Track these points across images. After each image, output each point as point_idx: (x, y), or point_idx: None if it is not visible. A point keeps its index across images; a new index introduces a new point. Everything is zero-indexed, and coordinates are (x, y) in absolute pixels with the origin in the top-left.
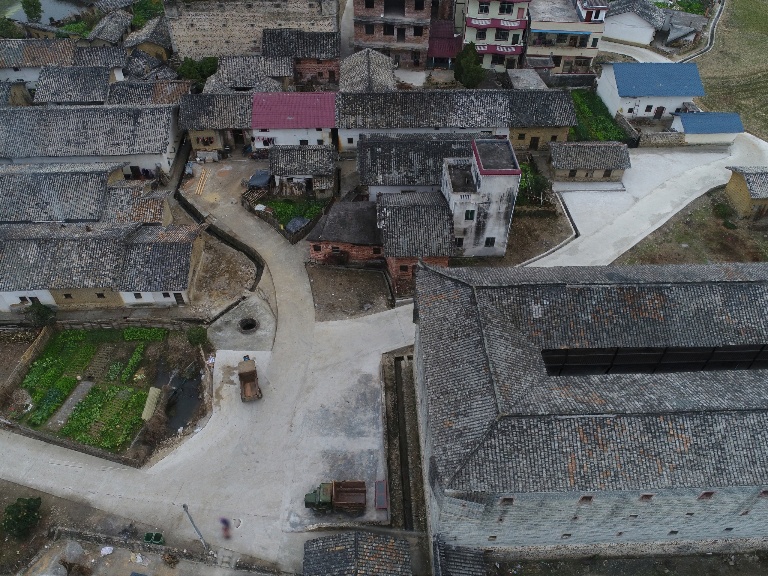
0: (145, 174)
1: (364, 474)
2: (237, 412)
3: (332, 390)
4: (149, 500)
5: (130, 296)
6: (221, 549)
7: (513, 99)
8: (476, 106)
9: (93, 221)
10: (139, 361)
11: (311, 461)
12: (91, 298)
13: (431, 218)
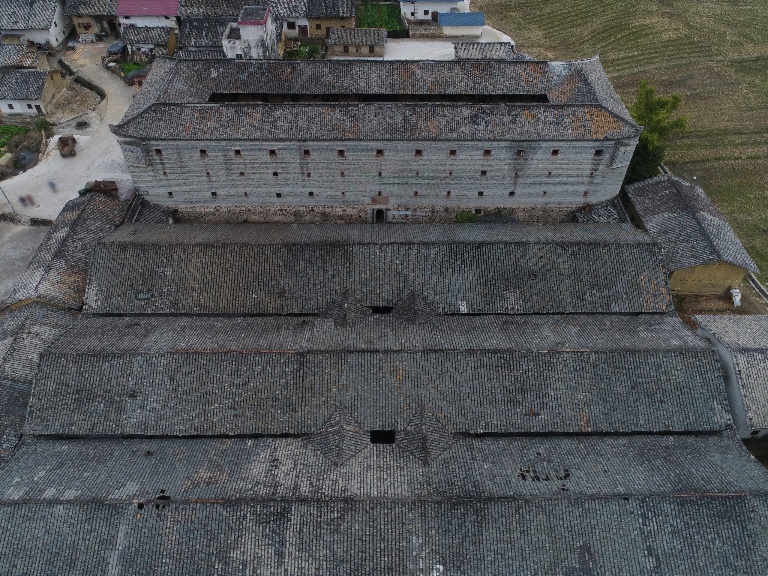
0: (39, 47)
1: (124, 188)
2: (57, 162)
3: None
4: None
5: (5, 107)
6: (24, 216)
7: None
8: (283, 2)
9: None
10: (5, 143)
11: None
12: None
13: None
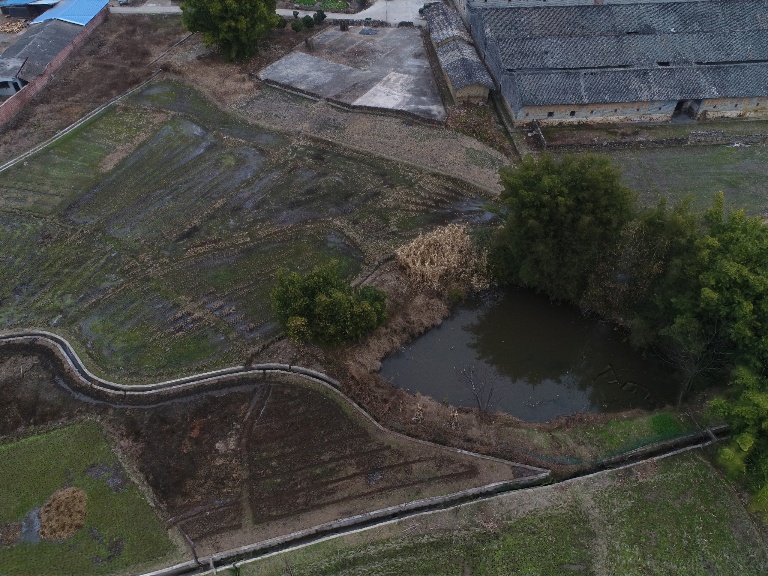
0: None
1: None
2: (385, 2)
3: None
4: None
5: None
6: (392, 23)
7: None
8: None
9: None
10: None
11: (417, 9)
12: None
13: None
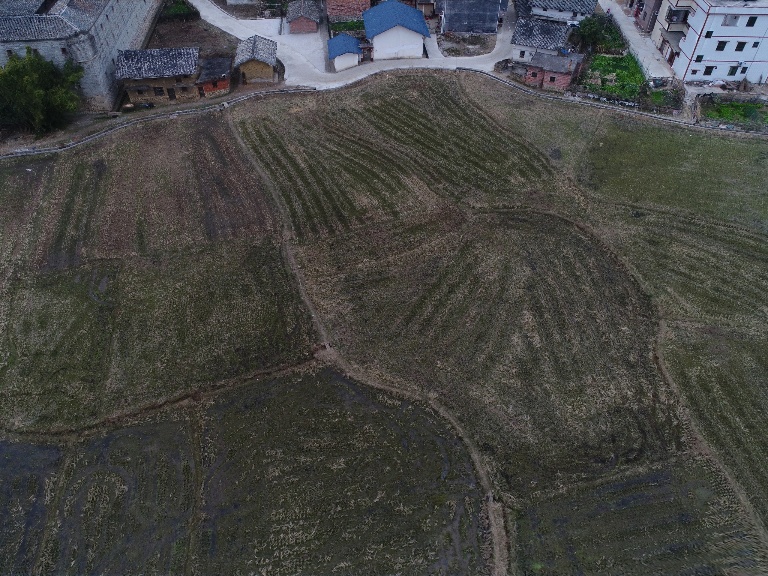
0: None
1: None
2: None
3: None
4: None
5: None
6: None
7: None
8: None
9: None
10: None
11: None
12: None
13: None
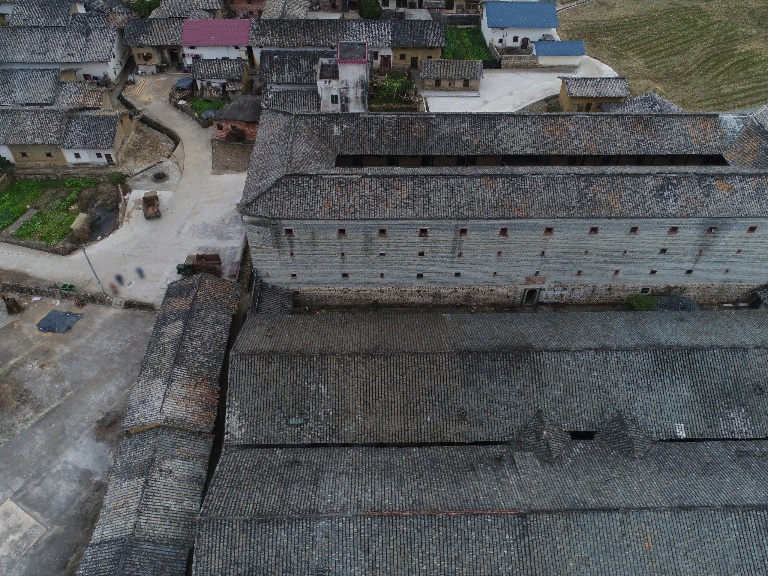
0: None
1: (225, 259)
2: (141, 225)
3: (213, 214)
4: (69, 272)
5: (71, 156)
6: (115, 297)
7: (395, 25)
8: (364, 30)
9: (47, 105)
10: (75, 199)
11: (189, 252)
12: (42, 157)
13: (303, 100)
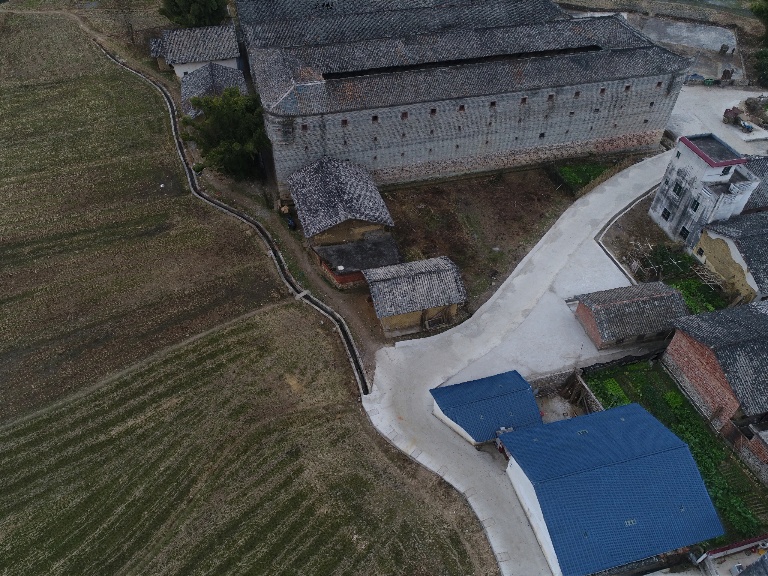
0: None
1: None
2: None
3: (691, 129)
4: None
5: None
6: None
7: None
8: None
9: None
10: None
11: None
12: None
13: None
